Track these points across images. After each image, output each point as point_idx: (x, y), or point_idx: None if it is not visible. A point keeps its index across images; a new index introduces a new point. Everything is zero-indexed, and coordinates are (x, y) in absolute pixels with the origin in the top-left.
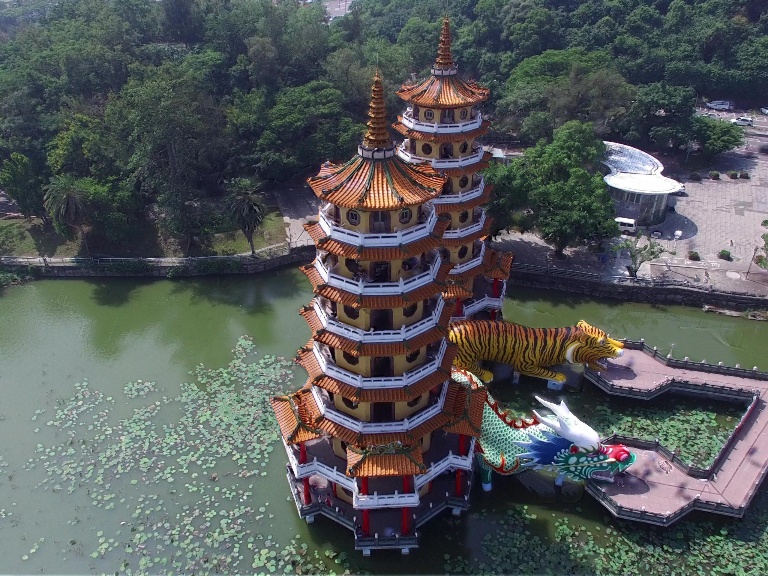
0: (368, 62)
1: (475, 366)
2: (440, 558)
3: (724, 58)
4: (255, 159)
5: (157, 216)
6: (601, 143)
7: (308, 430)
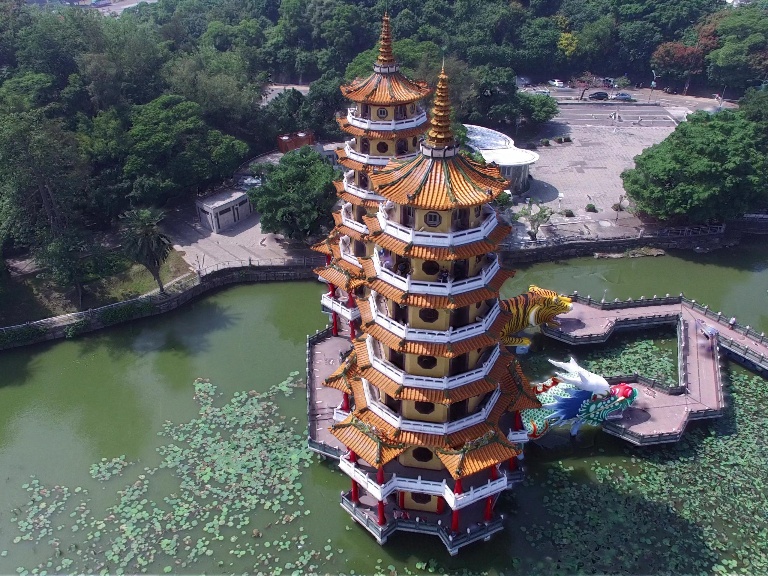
0: None
1: None
2: (518, 533)
3: (511, 40)
4: (125, 188)
5: (19, 272)
6: (462, 125)
7: (390, 448)
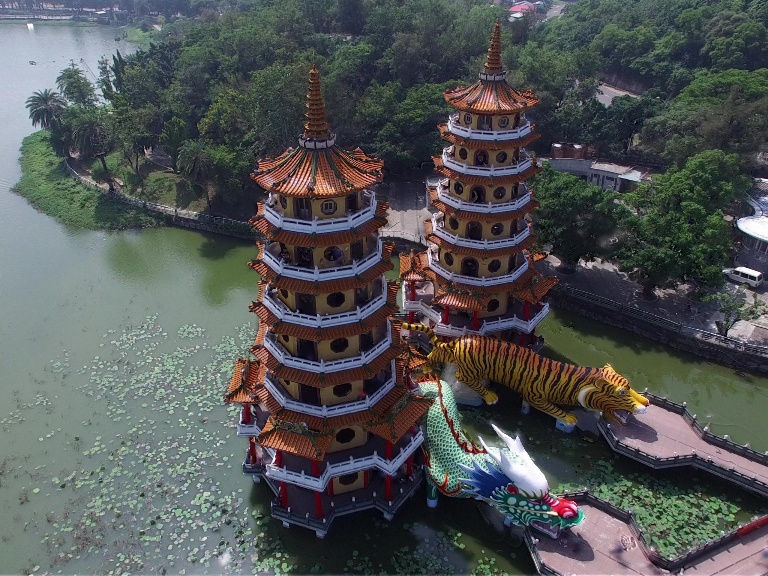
0: (520, 66)
1: (478, 384)
2: (349, 552)
3: None
4: (373, 148)
5: None
6: (746, 179)
7: (247, 393)
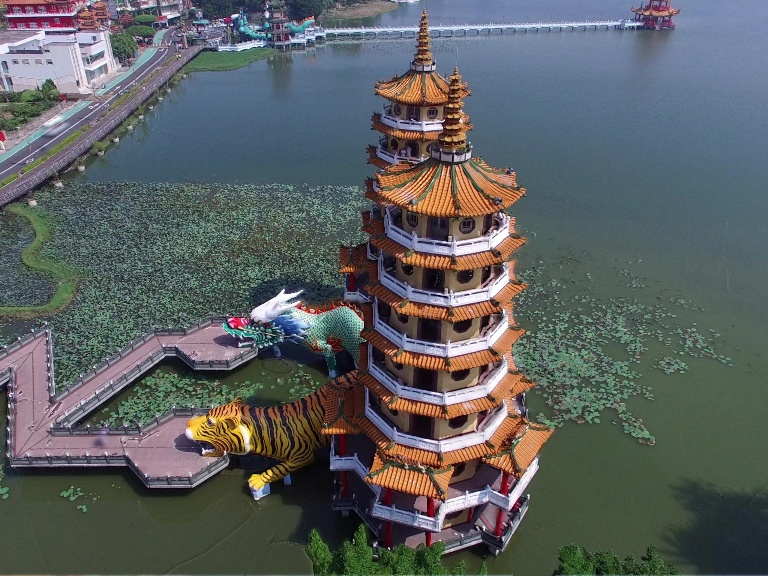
0: None
1: None
2: None
3: None
4: None
5: None
6: None
7: None
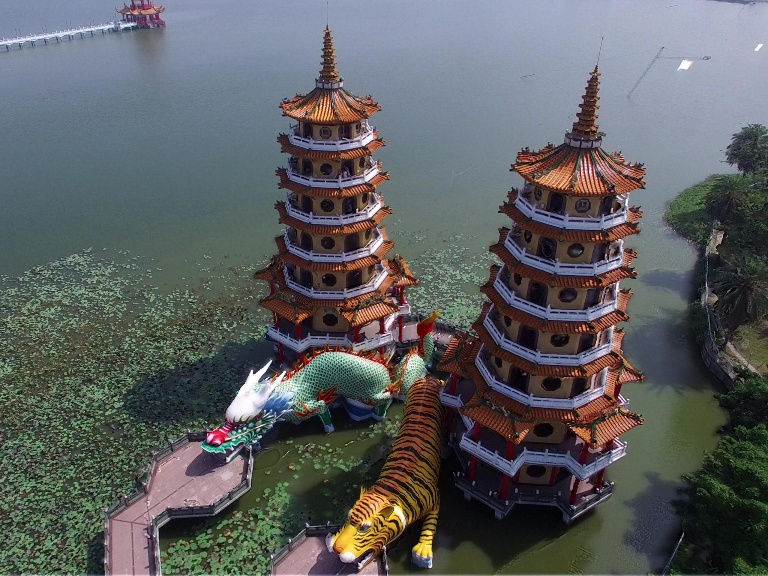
0: None
1: None
2: None
3: None
4: None
5: None
6: None
7: None
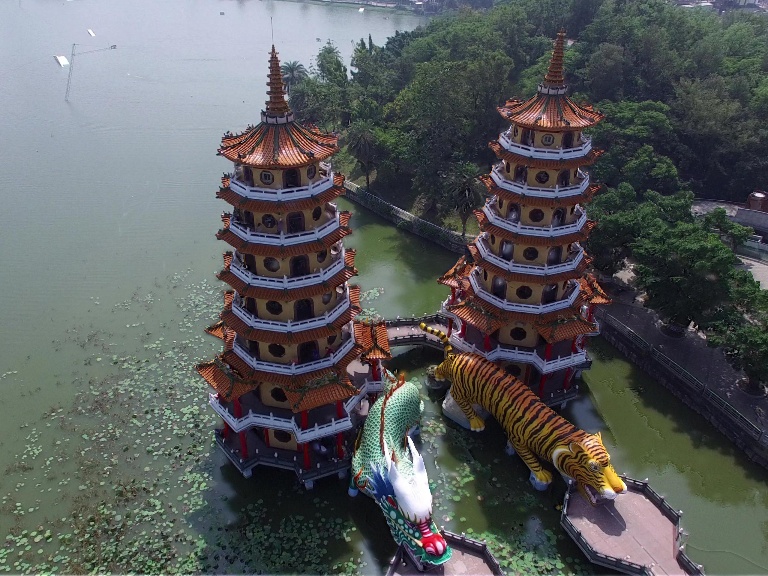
0: (752, 97)
1: (467, 405)
2: None
3: None
4: None
5: None
6: None
7: None
